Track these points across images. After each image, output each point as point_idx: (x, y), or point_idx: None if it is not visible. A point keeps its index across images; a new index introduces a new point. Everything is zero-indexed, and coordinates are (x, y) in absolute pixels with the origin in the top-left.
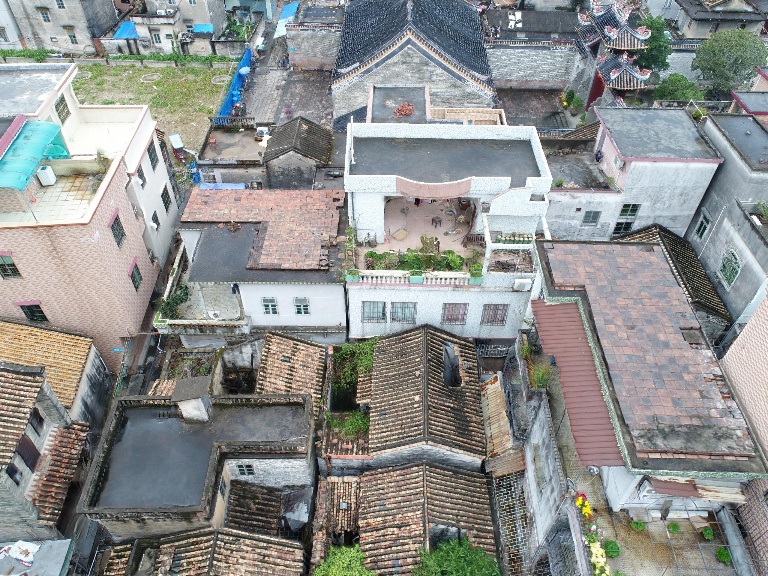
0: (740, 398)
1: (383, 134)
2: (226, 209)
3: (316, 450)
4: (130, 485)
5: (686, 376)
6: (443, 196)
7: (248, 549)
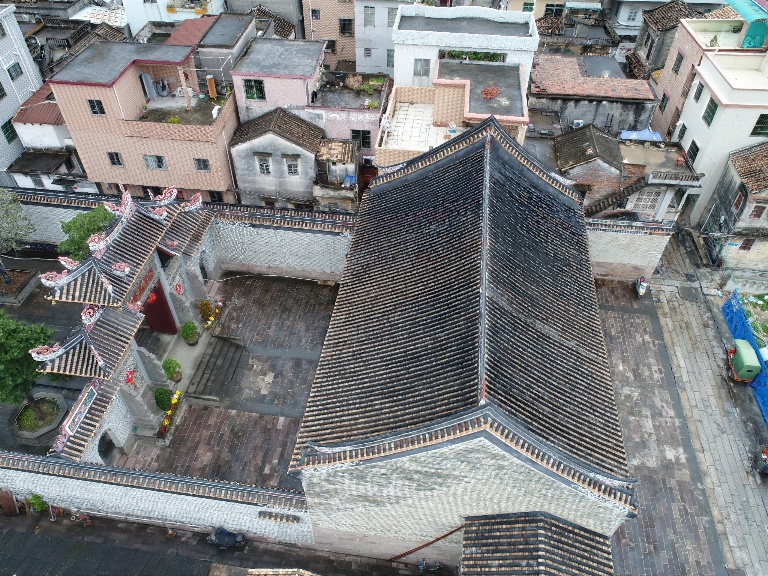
0: None
1: (510, 45)
2: (618, 85)
3: None
4: (595, 31)
5: None
6: (468, 16)
7: None
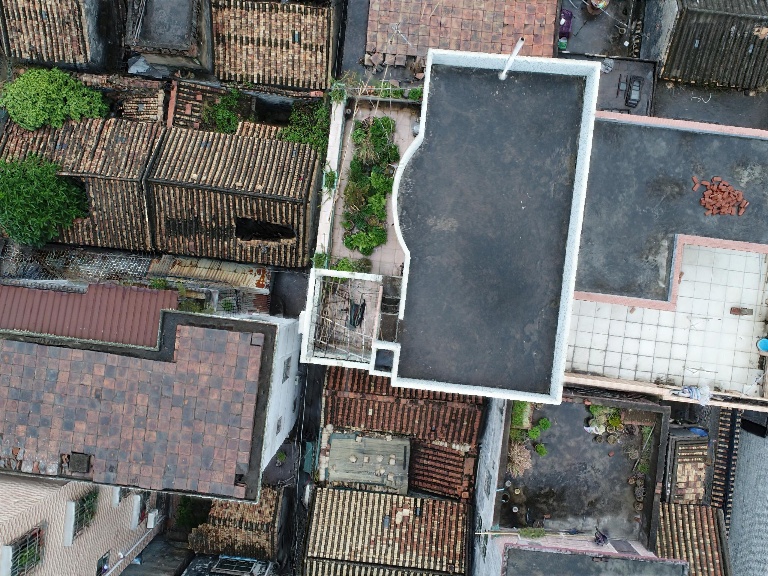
0: (4, 480)
1: None
2: None
3: (172, 72)
4: None
5: (22, 428)
6: None
7: (70, 6)
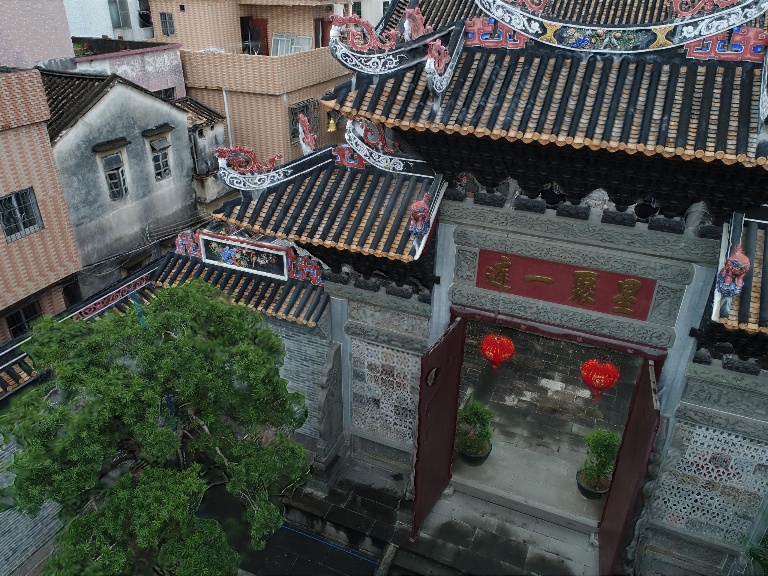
0: None
1: None
2: None
3: None
4: None
5: None
6: None
7: None
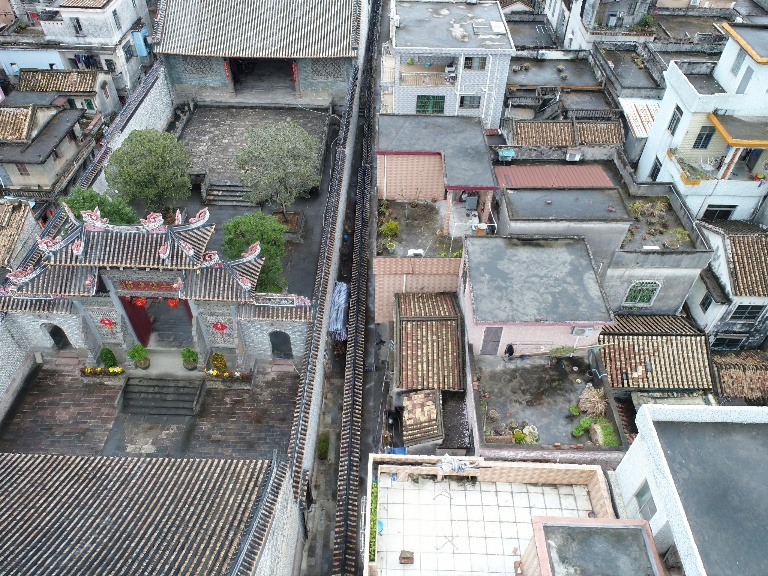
0: None
1: None
2: None
3: None
4: None
5: None
6: None
7: None
